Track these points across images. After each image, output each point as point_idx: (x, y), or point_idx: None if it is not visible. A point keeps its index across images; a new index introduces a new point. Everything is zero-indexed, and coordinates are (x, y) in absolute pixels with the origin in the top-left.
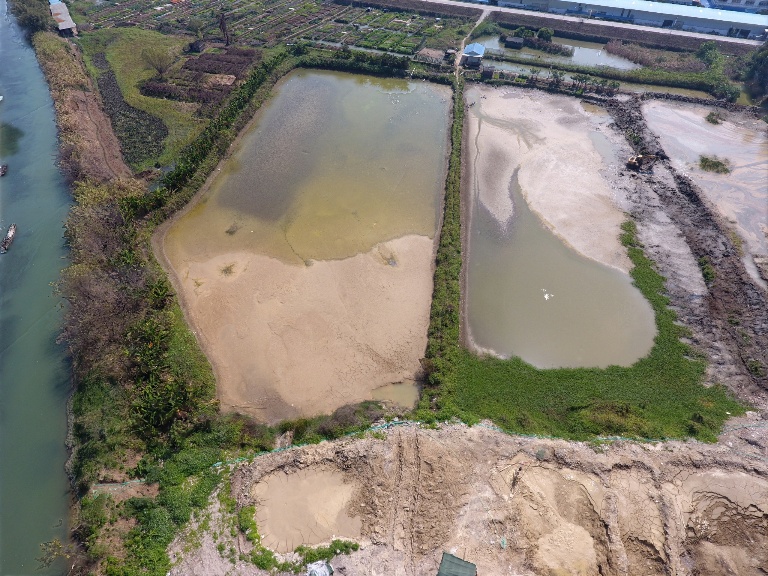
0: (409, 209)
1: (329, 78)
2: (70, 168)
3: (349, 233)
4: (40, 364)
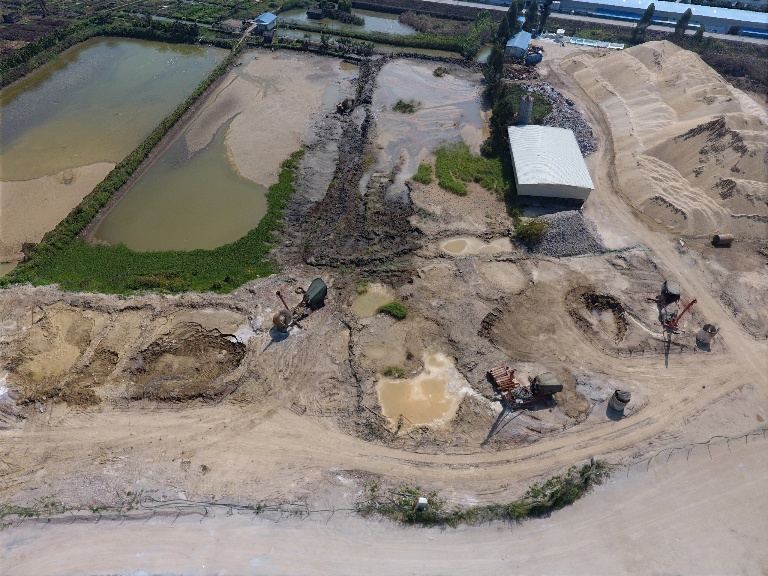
0: (115, 144)
1: (124, 44)
2: None
3: (47, 162)
4: None
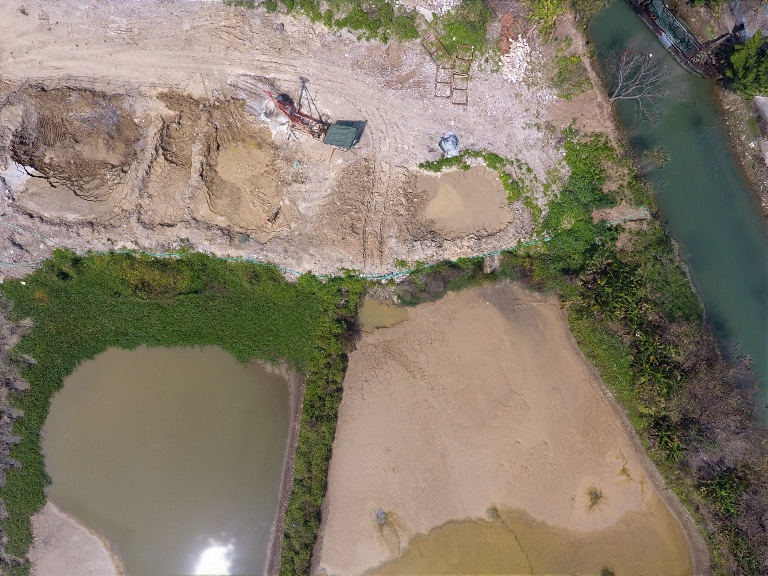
0: None
1: None
2: None
3: None
4: (752, 353)
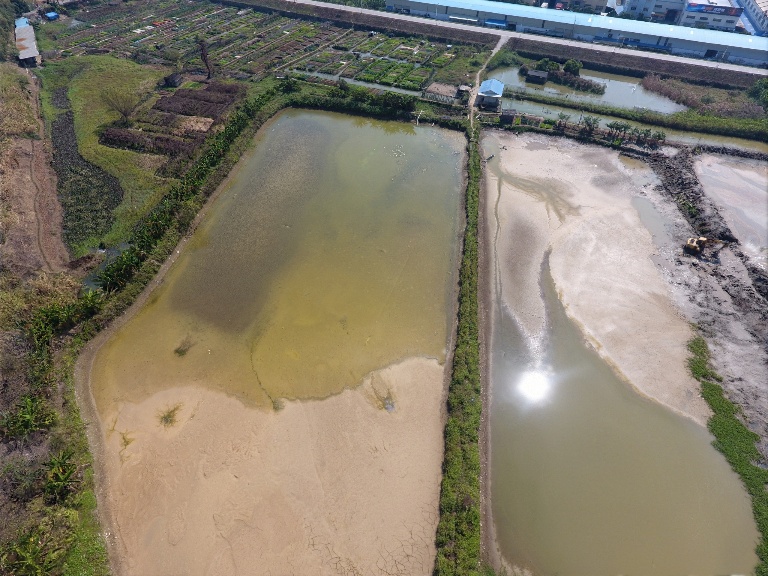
0: (413, 315)
1: (322, 121)
2: None
3: (334, 354)
4: None
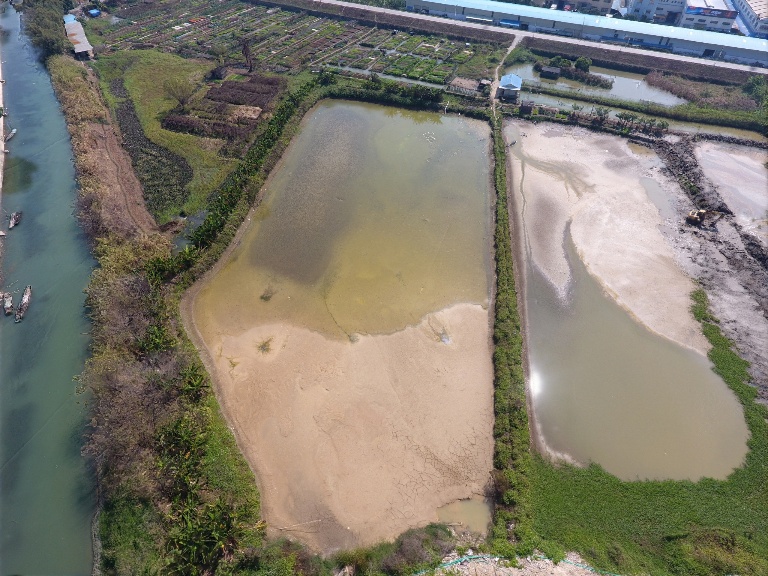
0: (457, 271)
1: (359, 110)
2: (91, 222)
3: (395, 300)
4: (60, 469)
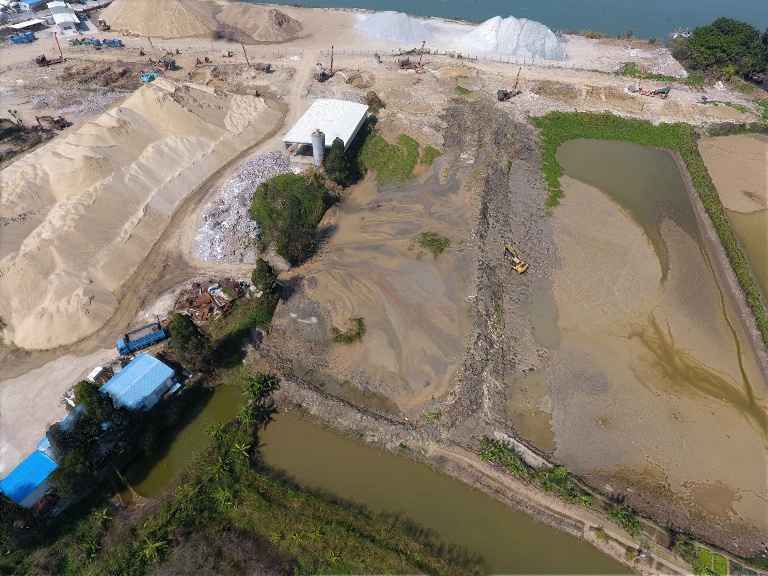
0: (765, 236)
1: None
2: None
3: None
4: None
